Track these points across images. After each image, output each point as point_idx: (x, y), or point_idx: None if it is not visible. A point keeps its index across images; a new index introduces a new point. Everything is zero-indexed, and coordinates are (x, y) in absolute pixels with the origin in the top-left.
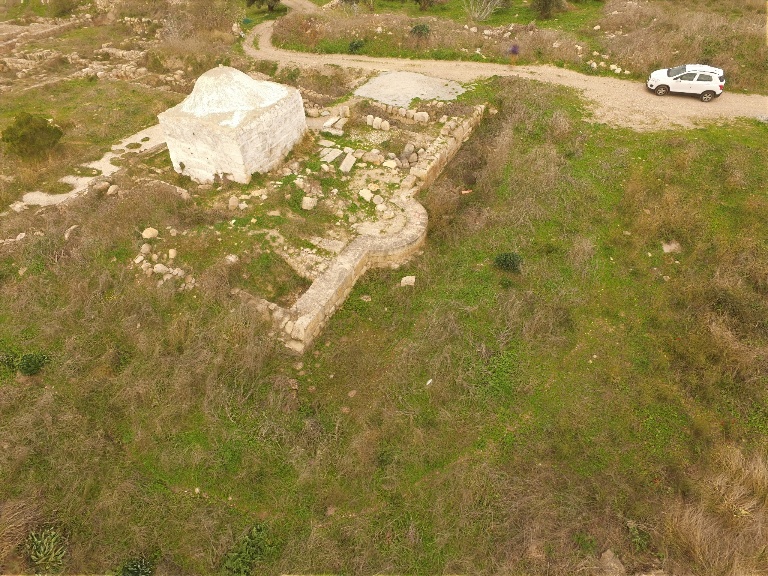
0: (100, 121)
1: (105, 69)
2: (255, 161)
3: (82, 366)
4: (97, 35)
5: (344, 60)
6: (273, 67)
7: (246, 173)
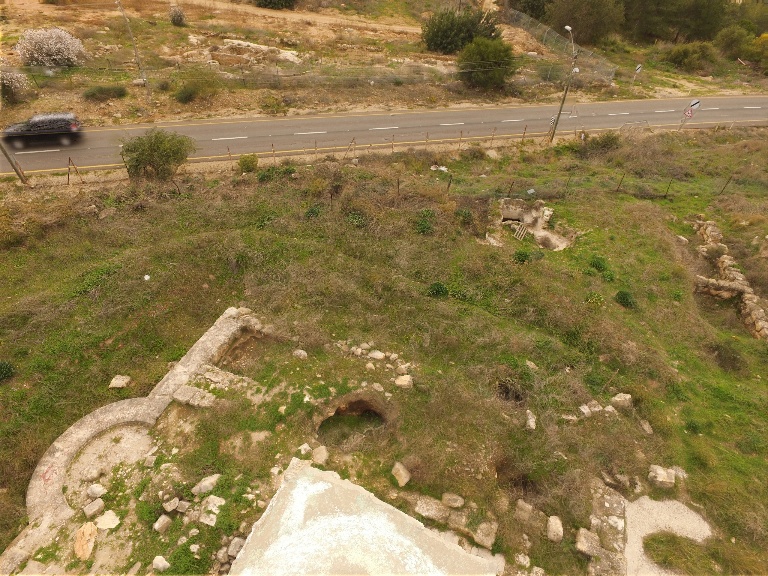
0: None
1: None
2: None
3: None
4: None
5: None
6: None
7: None
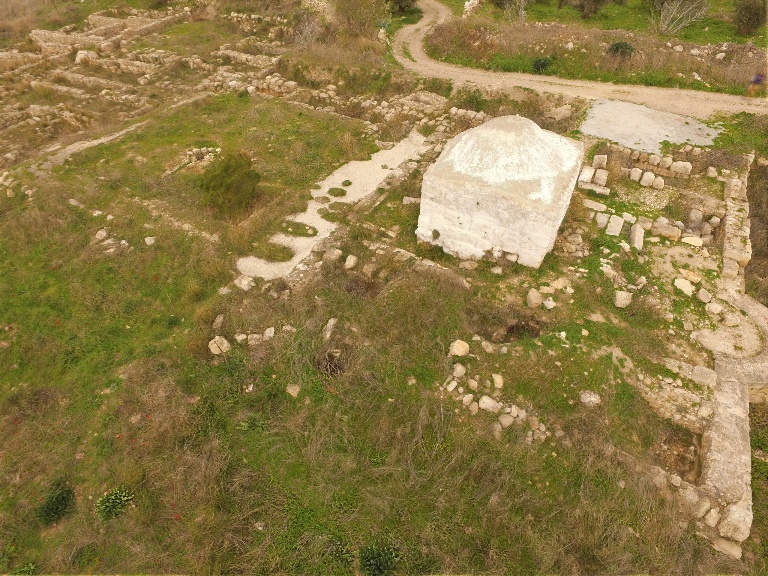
0: (280, 154)
1: (239, 78)
2: None
3: (452, 574)
4: (206, 33)
5: (533, 82)
6: (448, 87)
7: (542, 256)
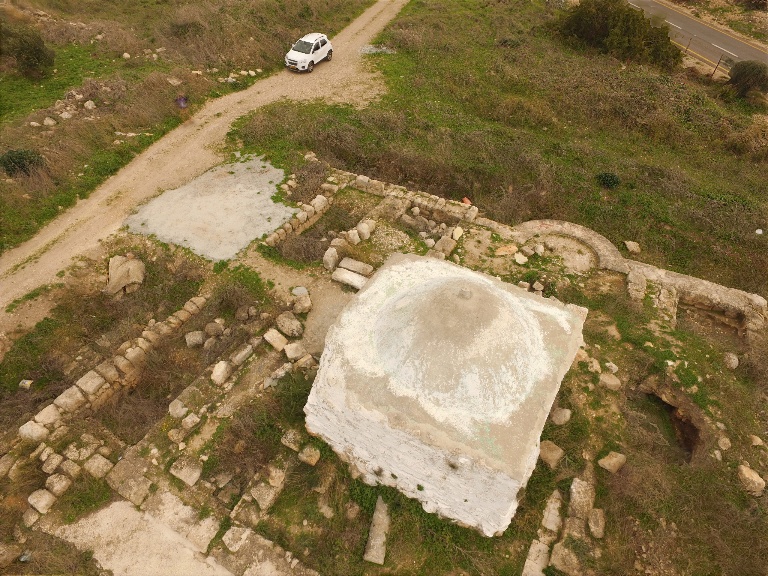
0: None
1: None
2: None
3: None
4: None
5: (5, 281)
6: None
7: None
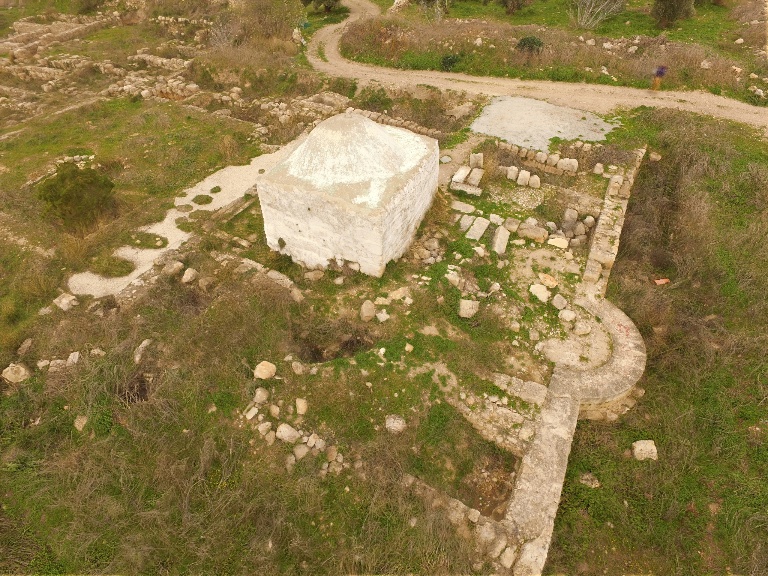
0: (154, 161)
1: (145, 83)
2: (391, 246)
3: None
4: (129, 37)
5: (439, 79)
6: (352, 87)
7: (381, 264)
